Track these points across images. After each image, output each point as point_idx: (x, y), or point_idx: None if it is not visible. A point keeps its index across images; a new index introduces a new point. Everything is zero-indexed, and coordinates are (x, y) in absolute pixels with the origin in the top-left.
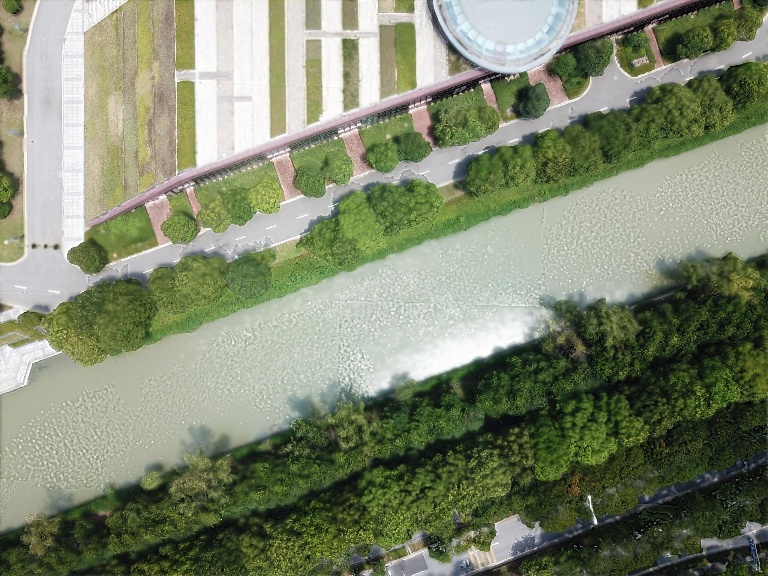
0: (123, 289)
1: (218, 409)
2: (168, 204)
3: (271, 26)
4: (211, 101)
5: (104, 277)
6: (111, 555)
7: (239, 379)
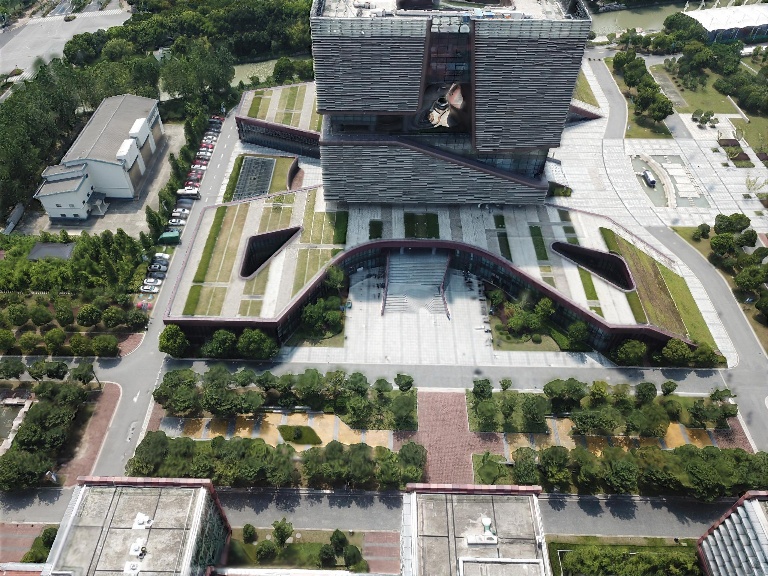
0: None
1: None
2: None
3: None
4: None
5: None
6: None
7: None
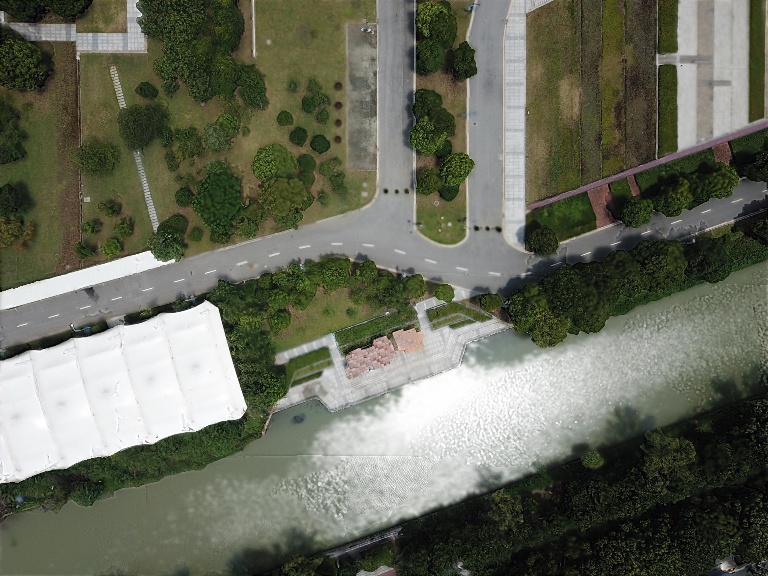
0: (607, 272)
1: (640, 390)
2: (607, 187)
3: (752, 9)
4: (691, 85)
5: (543, 259)
6: (565, 531)
7: (656, 361)
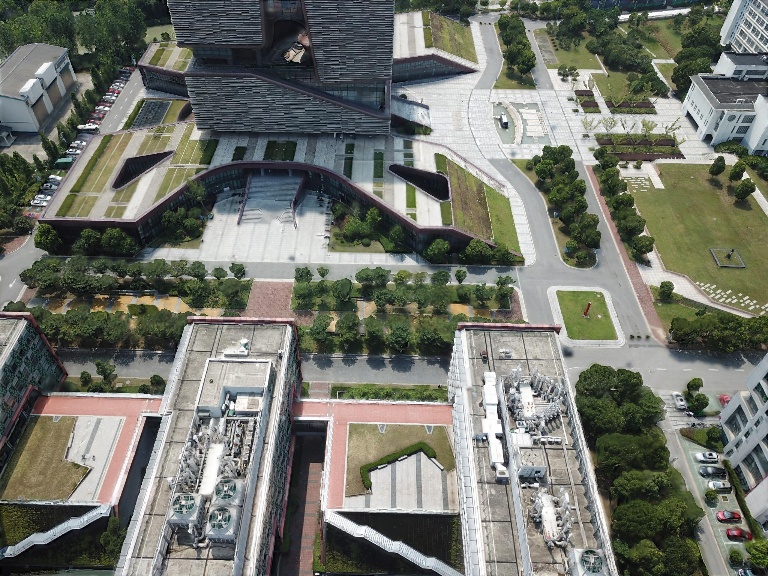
0: None
1: None
2: None
3: None
4: (416, 23)
5: None
6: None
7: None
